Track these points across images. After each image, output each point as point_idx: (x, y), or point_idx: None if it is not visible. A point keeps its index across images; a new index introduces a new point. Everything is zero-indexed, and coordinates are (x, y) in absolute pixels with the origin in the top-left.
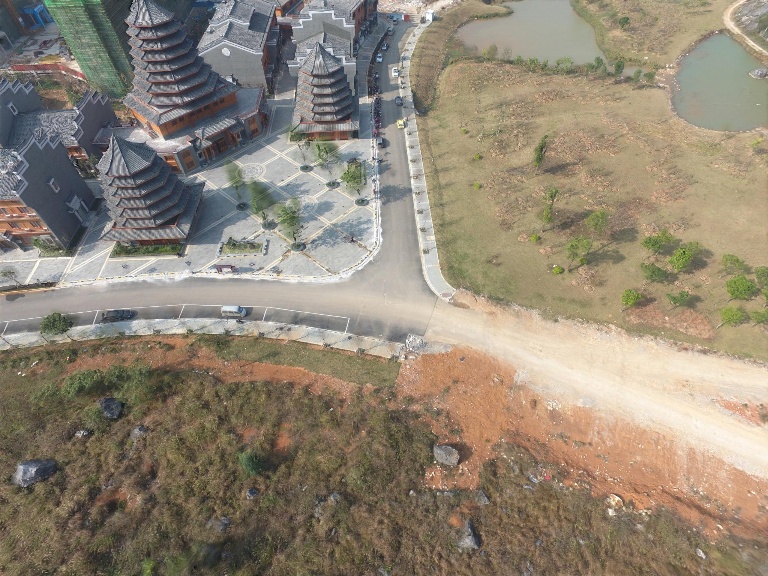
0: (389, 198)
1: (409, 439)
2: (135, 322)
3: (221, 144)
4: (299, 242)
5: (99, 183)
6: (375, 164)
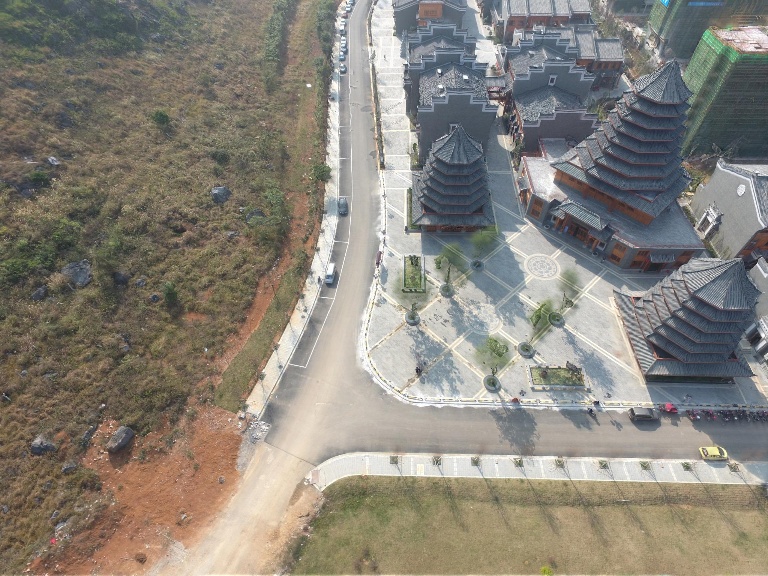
0: (505, 420)
1: (149, 408)
2: (335, 217)
3: (582, 232)
4: (419, 318)
5: (507, 163)
6: (584, 405)
